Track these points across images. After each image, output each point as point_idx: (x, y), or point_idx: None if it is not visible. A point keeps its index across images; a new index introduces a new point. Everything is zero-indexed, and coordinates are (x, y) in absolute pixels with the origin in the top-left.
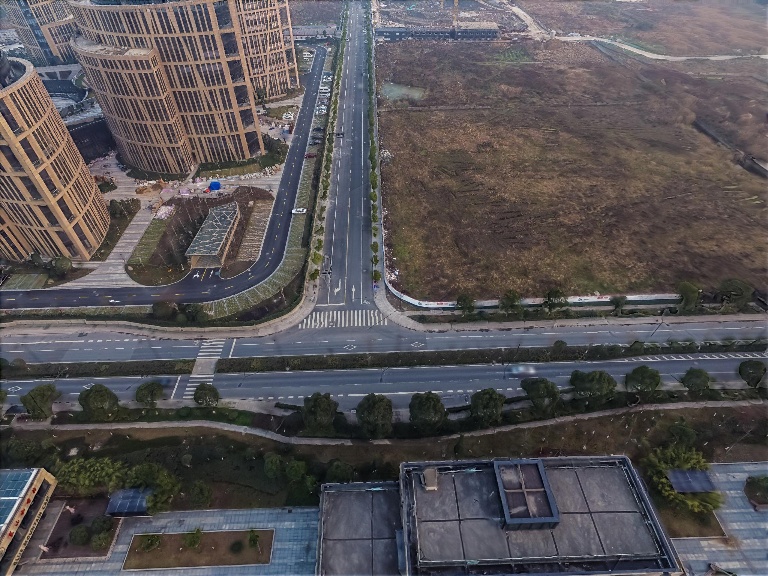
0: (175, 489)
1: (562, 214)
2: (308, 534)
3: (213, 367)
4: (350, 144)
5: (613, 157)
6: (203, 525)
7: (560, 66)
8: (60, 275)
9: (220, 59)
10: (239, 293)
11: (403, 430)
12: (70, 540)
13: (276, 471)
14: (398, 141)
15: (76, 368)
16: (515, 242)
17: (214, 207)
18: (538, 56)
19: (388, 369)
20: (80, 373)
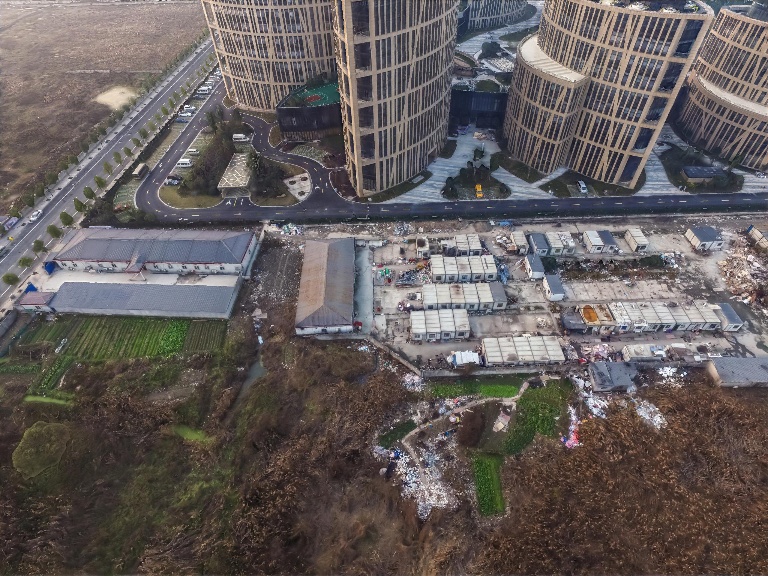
0: None
1: None
2: None
3: None
4: None
5: (57, 39)
6: None
7: None
8: None
9: None
10: None
11: None
12: None
13: None
14: (179, 50)
15: None
16: None
17: None
18: None
19: None
20: None
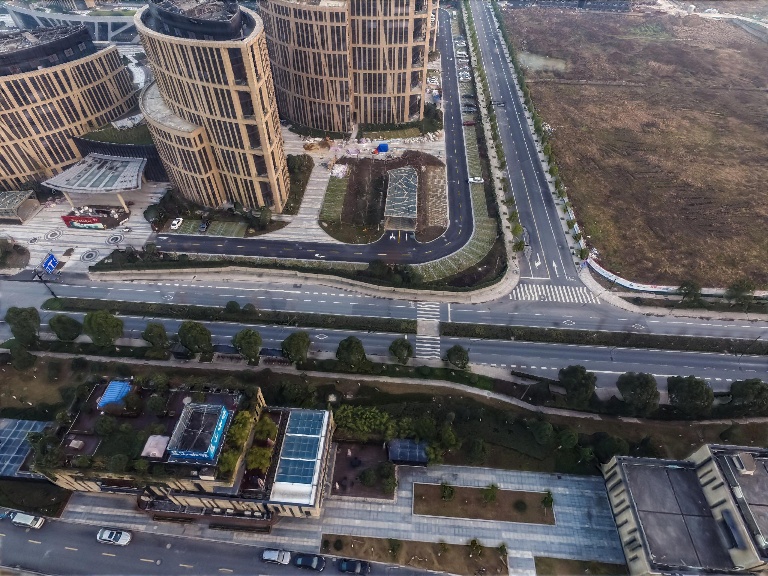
0: (460, 444)
1: (756, 205)
2: (585, 501)
3: (437, 329)
4: (504, 114)
5: None
6: (478, 481)
7: (706, 45)
8: (261, 225)
9: (408, 16)
10: (441, 258)
11: (654, 411)
12: (364, 481)
13: (550, 438)
14: (555, 114)
15: (304, 318)
16: (713, 230)
17: (391, 169)
18: (679, 32)
19: (616, 348)
20: (309, 323)
